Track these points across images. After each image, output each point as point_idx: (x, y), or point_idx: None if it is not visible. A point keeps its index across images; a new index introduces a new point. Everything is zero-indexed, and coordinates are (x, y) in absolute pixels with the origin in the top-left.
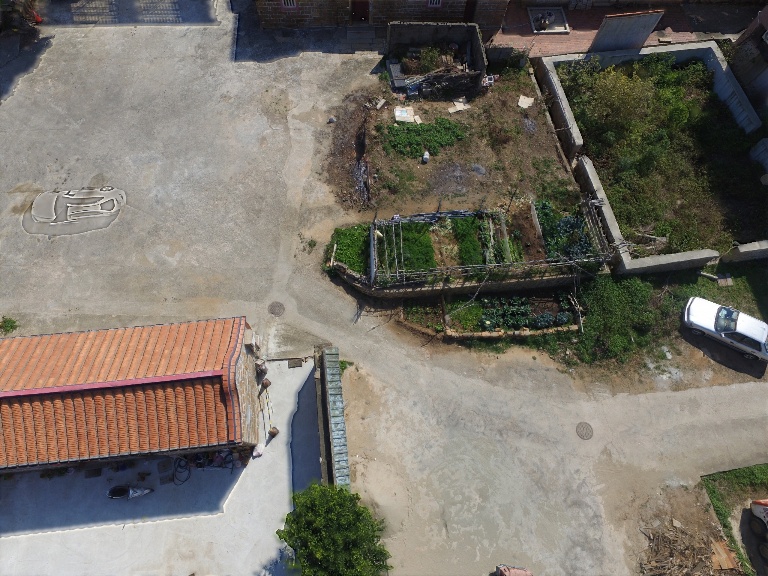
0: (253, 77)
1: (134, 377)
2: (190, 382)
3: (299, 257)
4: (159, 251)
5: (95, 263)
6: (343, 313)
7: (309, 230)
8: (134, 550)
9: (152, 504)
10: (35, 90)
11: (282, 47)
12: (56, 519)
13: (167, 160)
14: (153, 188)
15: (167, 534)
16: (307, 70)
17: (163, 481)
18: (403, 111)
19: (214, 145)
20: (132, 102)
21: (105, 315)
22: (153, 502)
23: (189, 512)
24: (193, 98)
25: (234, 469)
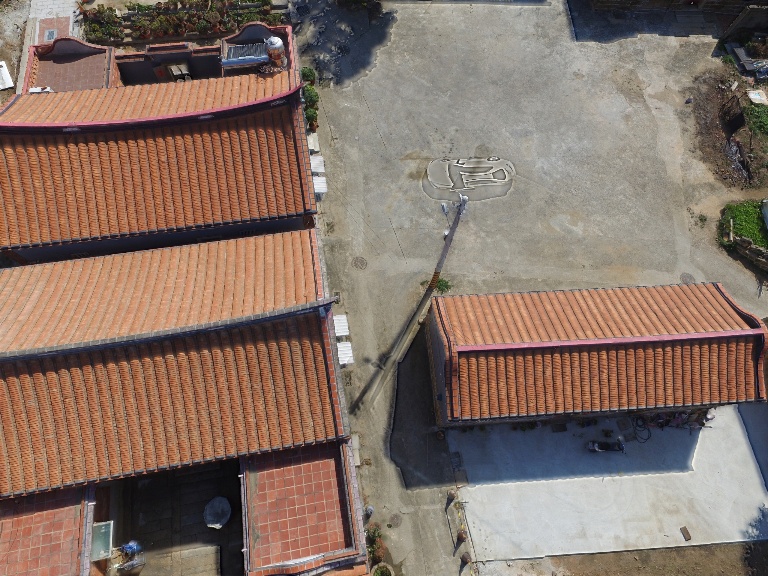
0: (599, 56)
1: (668, 333)
2: (726, 339)
3: (693, 231)
4: (562, 220)
5: (505, 229)
6: (747, 286)
7: (697, 205)
8: (620, 502)
9: (623, 459)
10: (395, 62)
11: (618, 28)
12: (537, 469)
13: (542, 133)
14: (537, 160)
15: (646, 488)
16: (649, 51)
17: (628, 438)
18: (756, 94)
19: (582, 121)
20: (491, 77)
21: (531, 279)
22: (624, 458)
23: (661, 469)
24: (548, 75)
25: (692, 430)
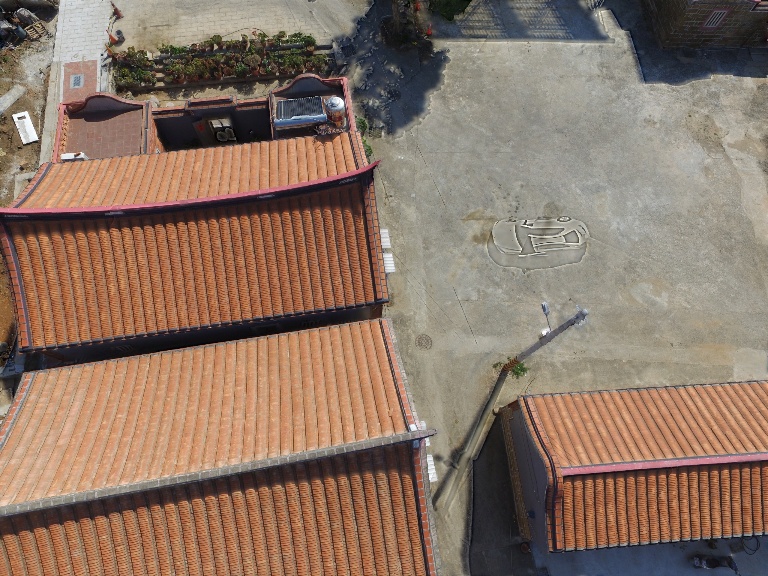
0: (670, 100)
1: None
2: None
3: None
4: (644, 290)
5: (582, 301)
6: None
7: None
8: None
9: (731, 575)
10: (450, 108)
11: (689, 68)
12: None
13: (615, 189)
14: (612, 220)
15: None
16: (724, 94)
17: (734, 549)
18: None
19: (658, 174)
20: (556, 124)
21: (615, 360)
22: (731, 573)
23: None
24: (616, 122)
25: None
